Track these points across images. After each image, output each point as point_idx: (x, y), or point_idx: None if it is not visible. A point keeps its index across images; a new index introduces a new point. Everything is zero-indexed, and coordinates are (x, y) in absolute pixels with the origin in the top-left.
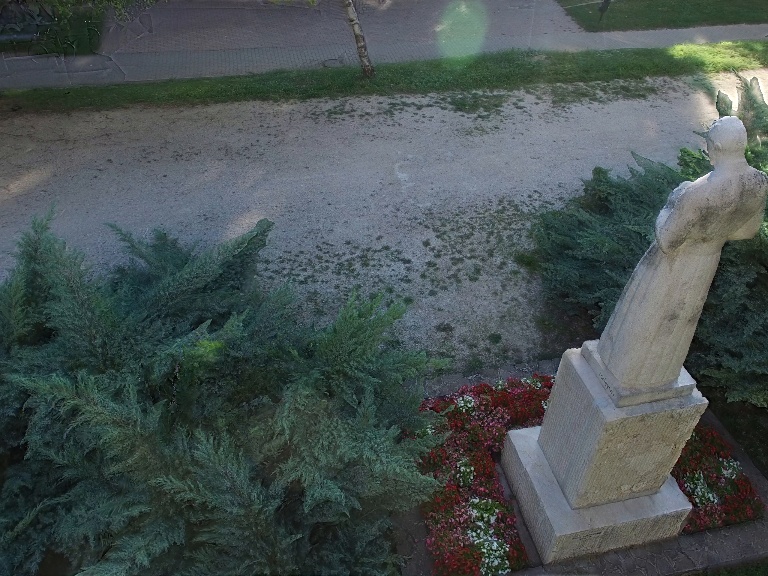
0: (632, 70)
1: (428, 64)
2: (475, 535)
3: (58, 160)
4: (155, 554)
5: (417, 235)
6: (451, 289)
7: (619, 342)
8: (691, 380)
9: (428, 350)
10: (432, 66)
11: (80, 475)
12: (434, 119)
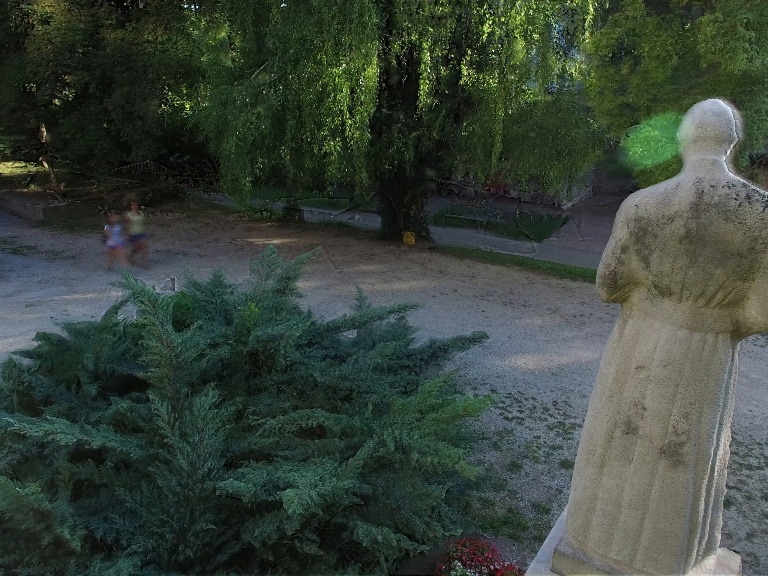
0: None
1: None
2: None
3: (423, 281)
4: None
5: None
6: None
7: None
8: None
9: None
10: None
11: None
12: None
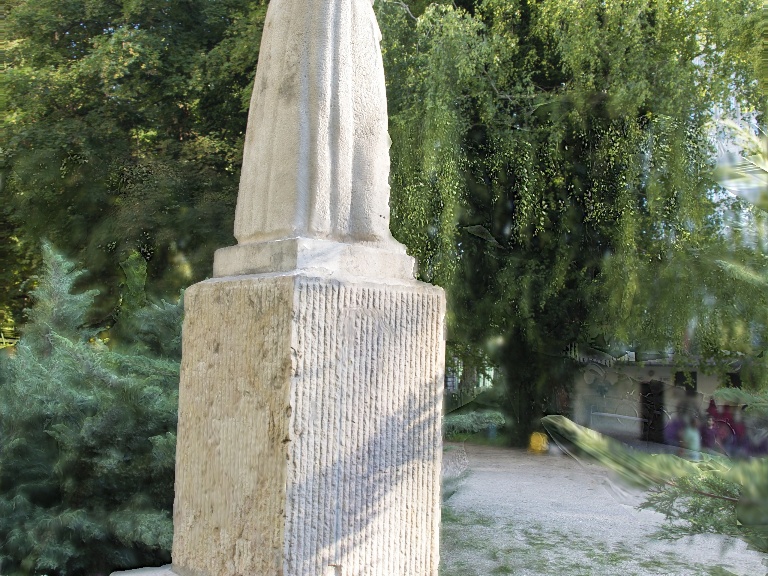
0: None
1: None
2: None
3: (527, 469)
4: None
5: None
6: None
7: None
8: None
9: None
10: None
11: None
12: None
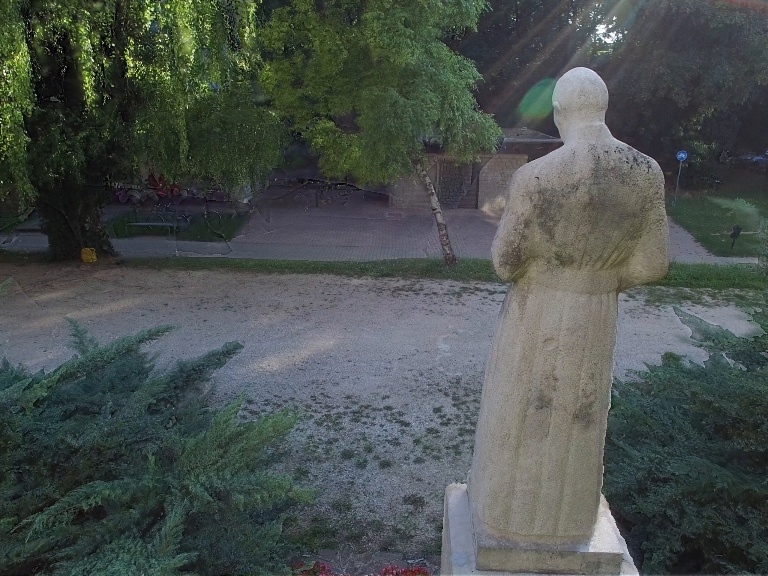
0: (752, 281)
1: None
2: None
3: (123, 300)
4: None
5: (431, 400)
6: (444, 460)
7: (478, 449)
8: (615, 546)
9: (382, 522)
10: None
11: None
12: None
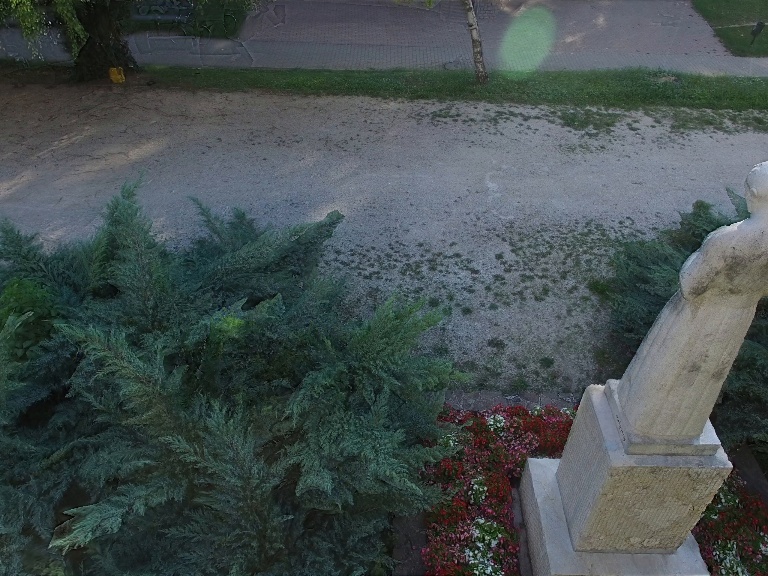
0: None
1: (546, 75)
2: (472, 555)
3: (175, 134)
4: (152, 504)
5: (492, 246)
6: (513, 306)
7: (636, 385)
8: (716, 440)
9: (475, 363)
10: (550, 78)
11: (112, 420)
12: (538, 132)
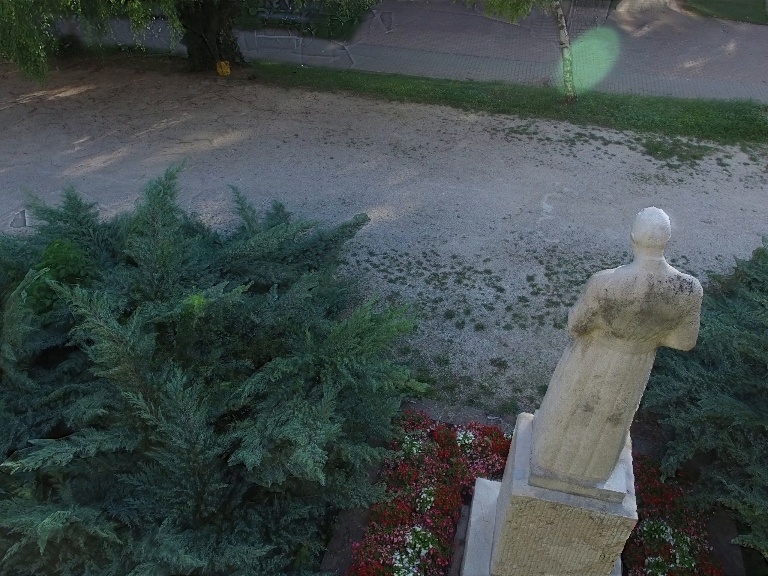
0: None
1: (643, 100)
2: (399, 558)
3: (259, 127)
4: (103, 448)
5: (526, 268)
6: (529, 329)
7: (541, 417)
8: (622, 487)
9: (471, 379)
10: (645, 103)
11: None
12: (615, 157)
